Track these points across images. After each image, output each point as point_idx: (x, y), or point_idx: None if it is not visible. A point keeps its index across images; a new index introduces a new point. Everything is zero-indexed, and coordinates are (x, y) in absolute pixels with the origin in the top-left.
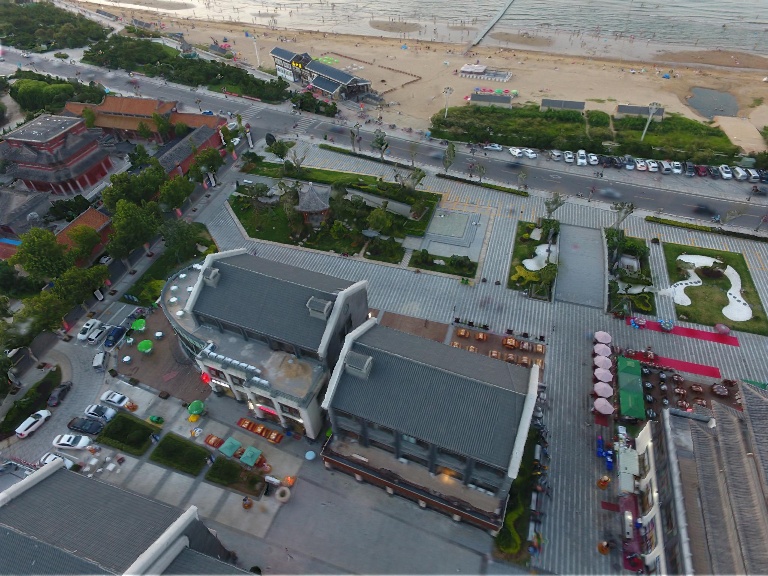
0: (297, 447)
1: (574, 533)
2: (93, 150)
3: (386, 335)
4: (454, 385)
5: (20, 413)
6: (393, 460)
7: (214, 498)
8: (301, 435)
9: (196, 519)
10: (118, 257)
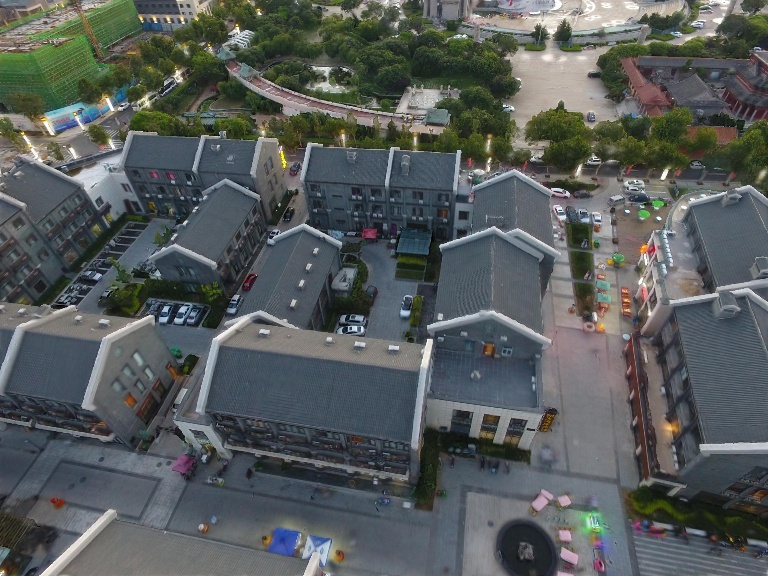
0: (628, 328)
1: (685, 575)
2: None
3: None
4: (763, 381)
5: (562, 185)
6: (659, 384)
7: (566, 292)
8: (639, 329)
9: None
10: (705, 164)
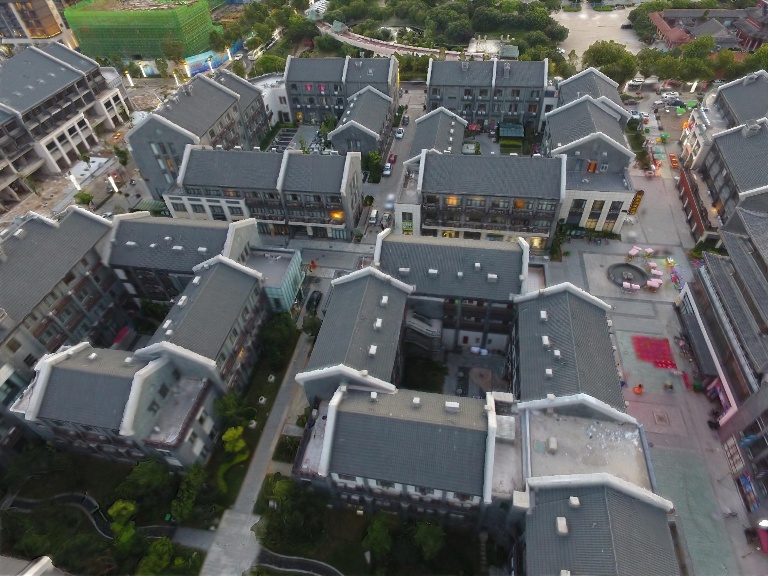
0: (677, 175)
1: None
2: None
3: None
4: None
5: None
6: (705, 191)
7: None
8: None
9: (627, 120)
10: (725, 76)
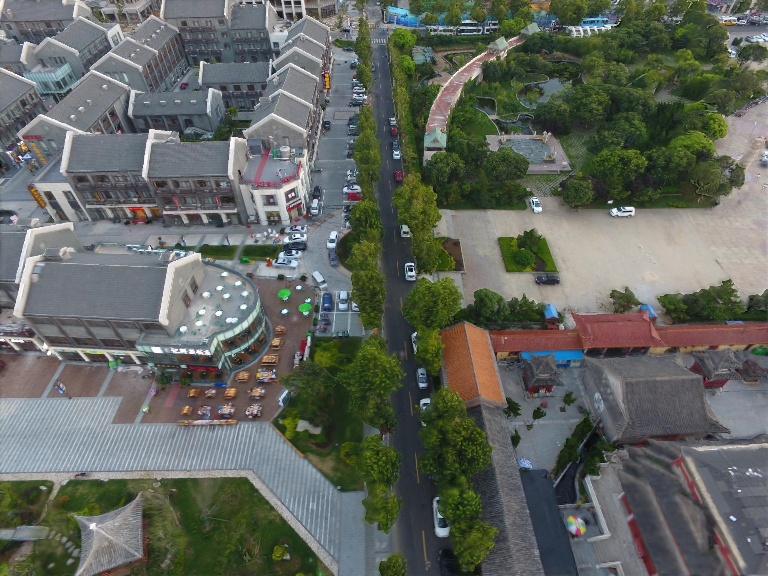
0: None
1: None
2: (687, 567)
3: (7, 263)
4: None
5: None
6: None
7: None
8: None
9: None
10: None
